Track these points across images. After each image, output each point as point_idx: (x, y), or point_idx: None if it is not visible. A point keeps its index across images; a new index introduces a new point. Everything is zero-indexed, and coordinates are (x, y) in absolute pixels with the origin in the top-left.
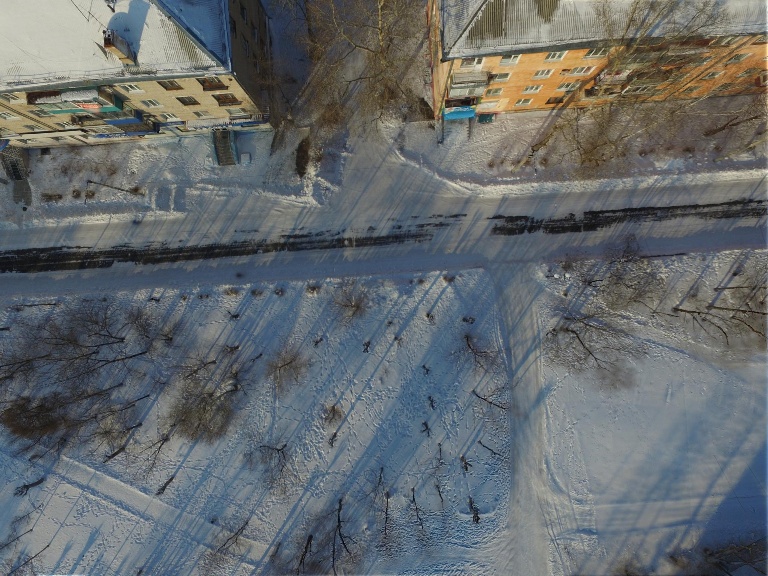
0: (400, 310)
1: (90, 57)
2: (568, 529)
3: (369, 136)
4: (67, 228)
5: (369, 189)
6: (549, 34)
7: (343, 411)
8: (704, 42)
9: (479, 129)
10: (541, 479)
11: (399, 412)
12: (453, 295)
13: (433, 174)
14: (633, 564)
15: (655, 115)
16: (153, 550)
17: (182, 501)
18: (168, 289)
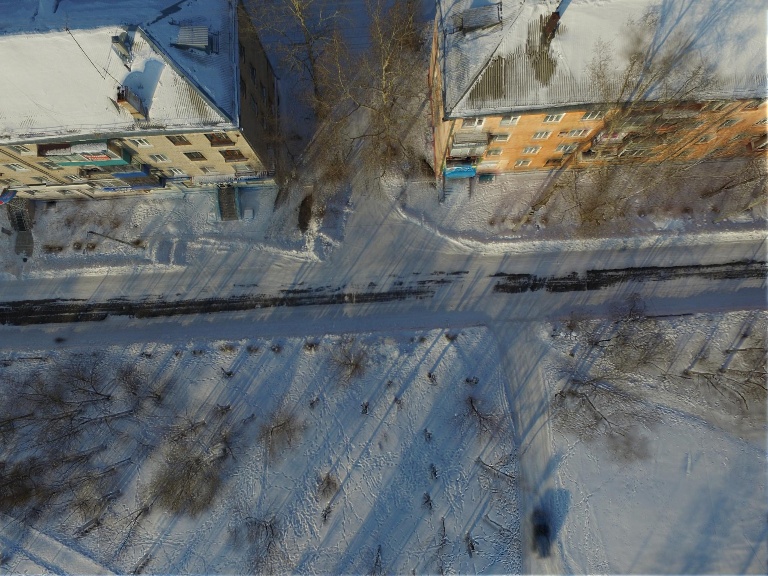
0: (401, 369)
1: (103, 112)
2: None
3: (371, 195)
4: (63, 280)
5: (371, 245)
6: (547, 97)
7: (338, 479)
8: (696, 107)
9: (480, 189)
10: (555, 561)
11: (399, 481)
12: (456, 354)
13: (435, 232)
14: None
15: (651, 178)
16: None
17: None
18: (160, 344)
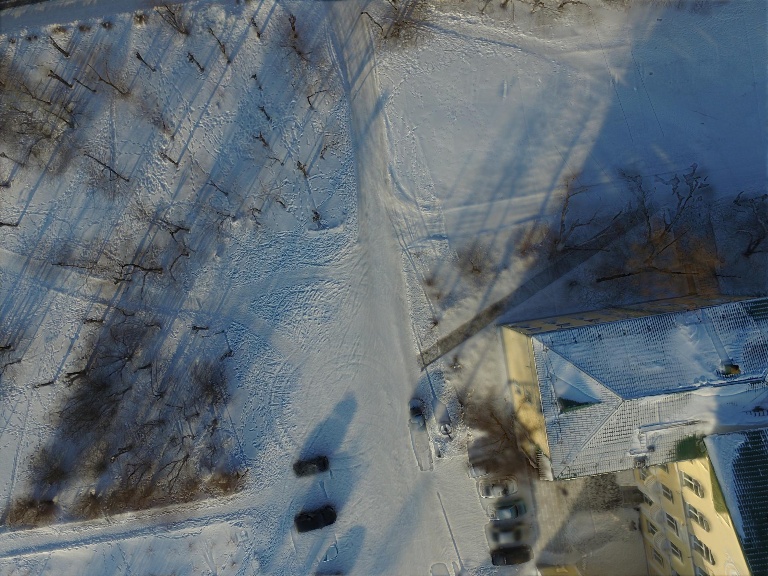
0: (231, 34)
1: None
2: (419, 237)
3: None
4: None
5: None
6: None
7: (182, 140)
8: None
9: None
10: (387, 189)
11: (239, 136)
12: (282, 13)
13: None
14: (486, 264)
15: None
16: (3, 300)
17: (29, 248)
18: None
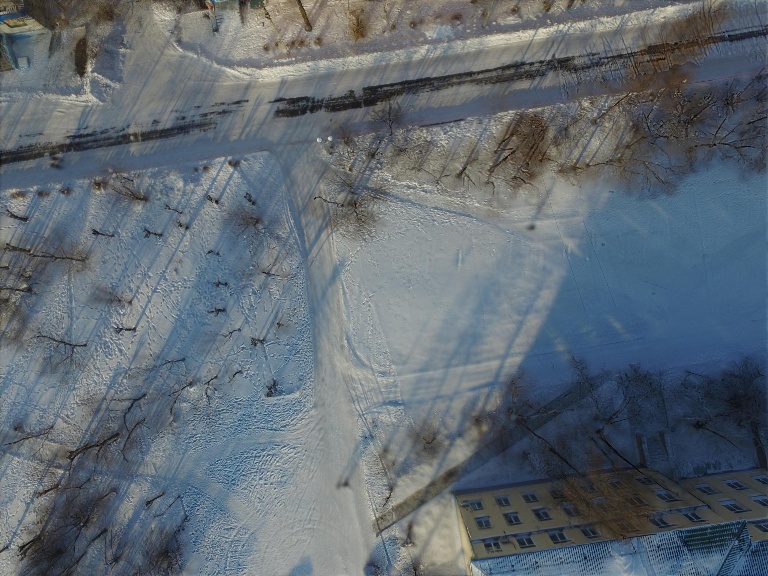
0: (190, 200)
1: None
2: (374, 403)
3: (146, 31)
4: None
5: (150, 83)
6: None
7: (140, 305)
8: None
9: (252, 14)
10: (343, 355)
11: (196, 301)
12: (240, 180)
13: (211, 62)
14: (440, 431)
15: None
16: None
17: None
18: None
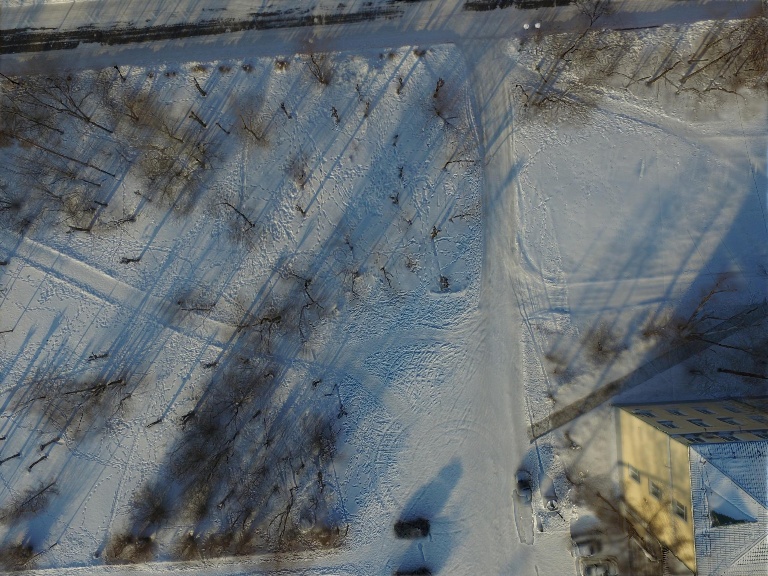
0: (370, 88)
1: None
2: (540, 309)
3: None
4: (31, 8)
5: None
6: None
7: (312, 190)
8: None
9: None
10: (513, 258)
11: (369, 191)
12: (424, 71)
13: None
14: (606, 342)
15: None
16: (119, 333)
17: (148, 284)
18: (134, 67)
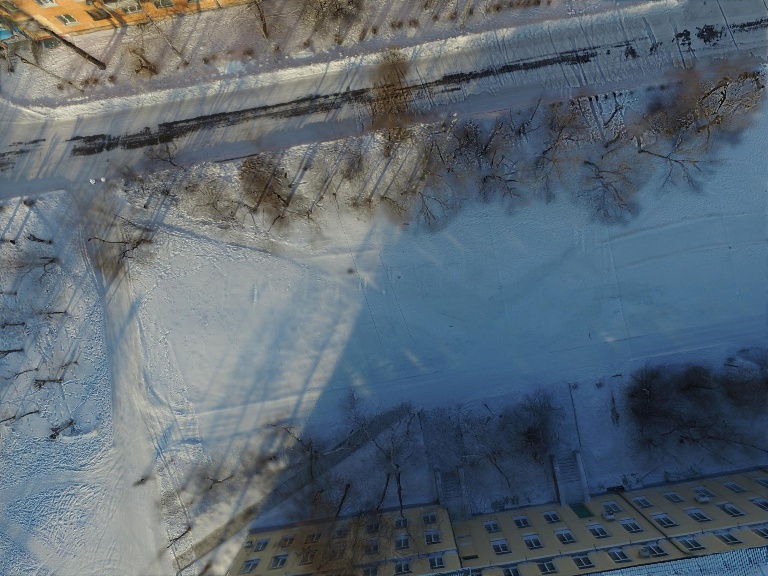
0: None
1: None
2: (173, 441)
3: None
4: None
5: None
6: None
7: None
8: None
9: (47, 54)
10: (141, 393)
11: None
12: (37, 219)
13: (7, 103)
14: (239, 468)
15: (216, 23)
16: None
17: None
18: None
